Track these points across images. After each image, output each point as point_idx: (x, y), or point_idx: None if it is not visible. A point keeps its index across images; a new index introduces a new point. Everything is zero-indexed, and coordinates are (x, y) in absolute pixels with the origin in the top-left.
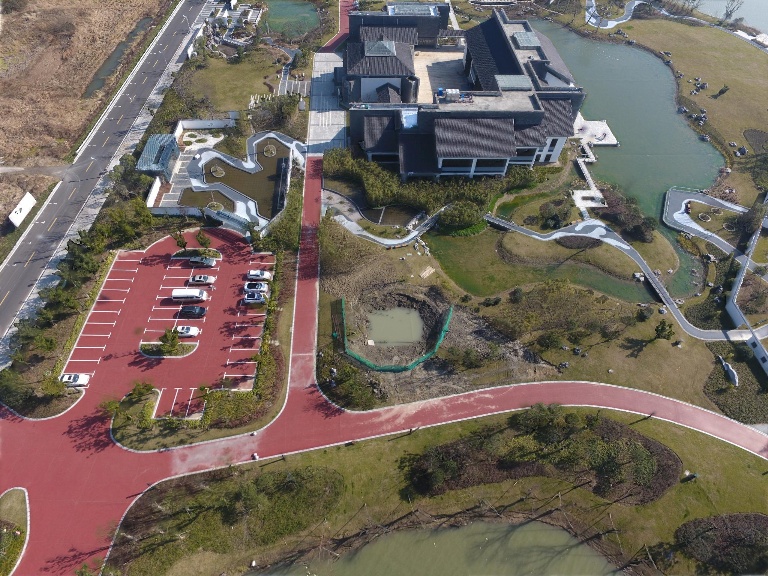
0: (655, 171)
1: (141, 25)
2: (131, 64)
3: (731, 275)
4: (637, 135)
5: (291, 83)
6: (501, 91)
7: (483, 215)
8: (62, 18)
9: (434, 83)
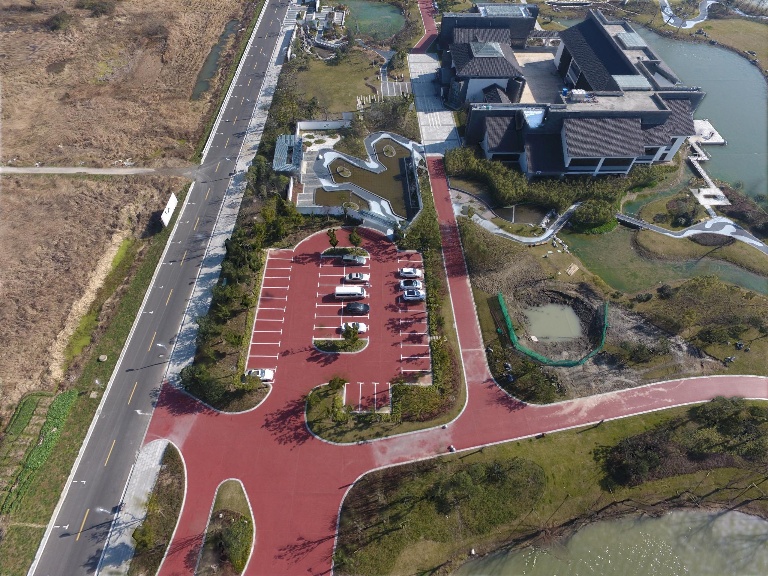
0: (767, 169)
1: (230, 28)
2: (232, 66)
3: None
4: (741, 134)
5: (392, 84)
6: (623, 91)
7: (615, 213)
8: (153, 21)
9: (531, 83)
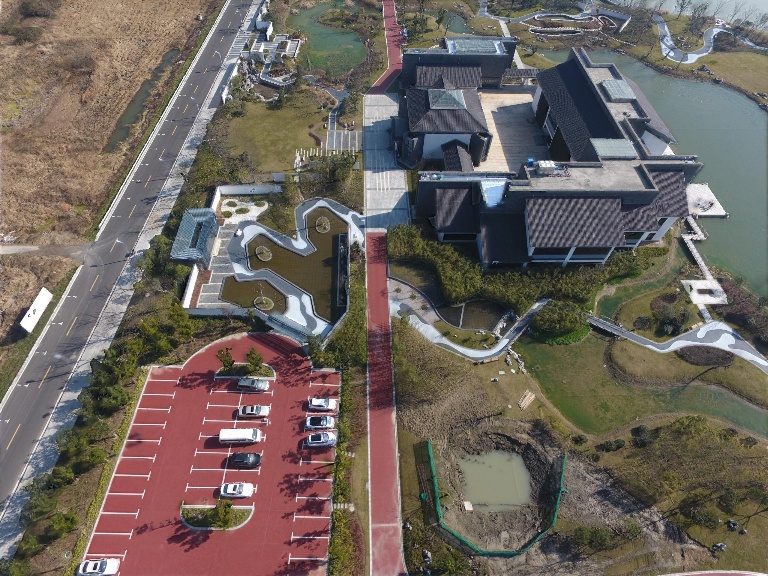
0: None
1: (167, 59)
2: (158, 109)
3: None
4: (746, 202)
5: (340, 134)
6: (602, 161)
7: (586, 319)
8: (80, 51)
9: (502, 134)
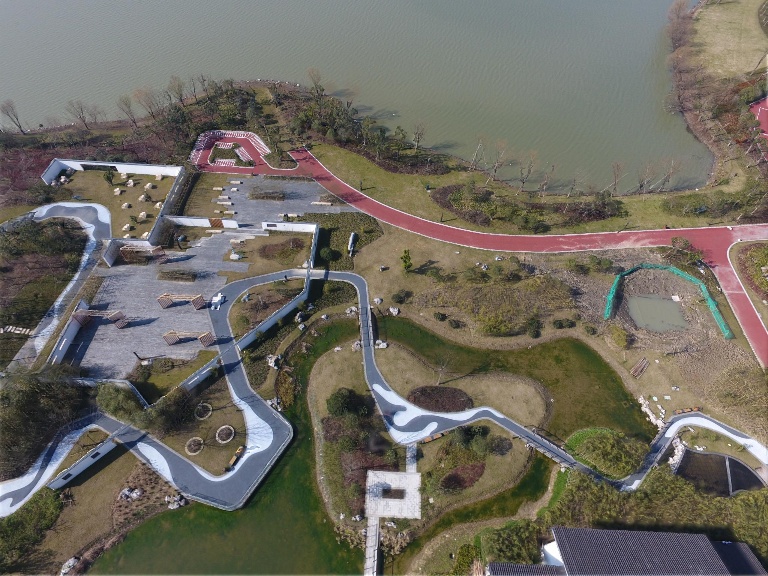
0: None
1: None
2: None
3: (268, 335)
4: None
5: None
6: None
7: None
8: None
9: None
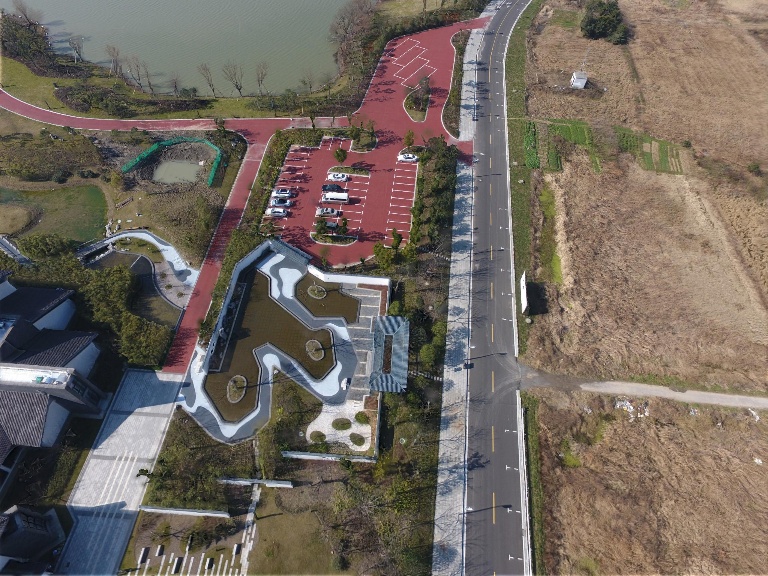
0: None
1: None
2: None
3: None
4: None
5: None
6: None
7: None
8: None
9: None
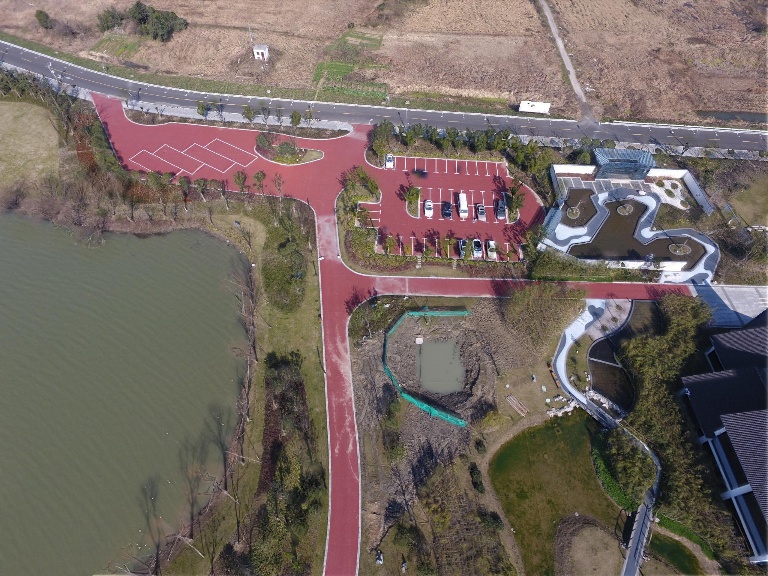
0: None
1: None
2: None
3: None
4: None
5: None
6: None
7: (638, 498)
8: None
9: None
